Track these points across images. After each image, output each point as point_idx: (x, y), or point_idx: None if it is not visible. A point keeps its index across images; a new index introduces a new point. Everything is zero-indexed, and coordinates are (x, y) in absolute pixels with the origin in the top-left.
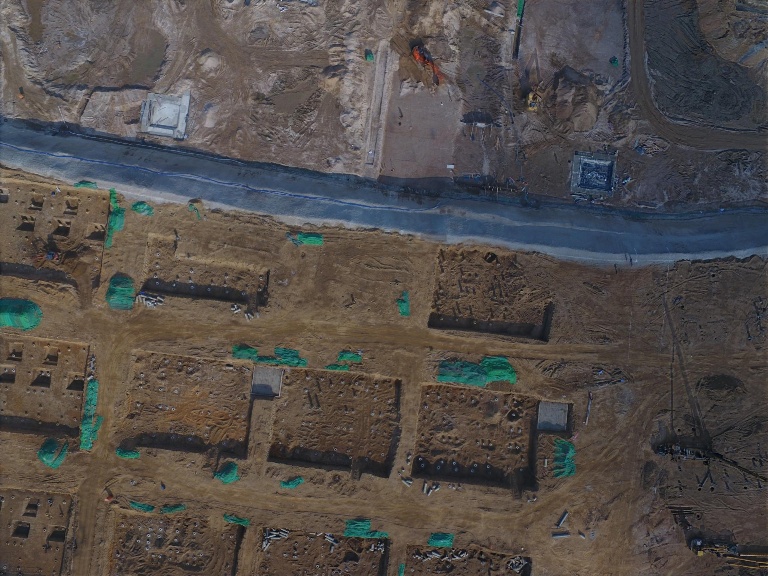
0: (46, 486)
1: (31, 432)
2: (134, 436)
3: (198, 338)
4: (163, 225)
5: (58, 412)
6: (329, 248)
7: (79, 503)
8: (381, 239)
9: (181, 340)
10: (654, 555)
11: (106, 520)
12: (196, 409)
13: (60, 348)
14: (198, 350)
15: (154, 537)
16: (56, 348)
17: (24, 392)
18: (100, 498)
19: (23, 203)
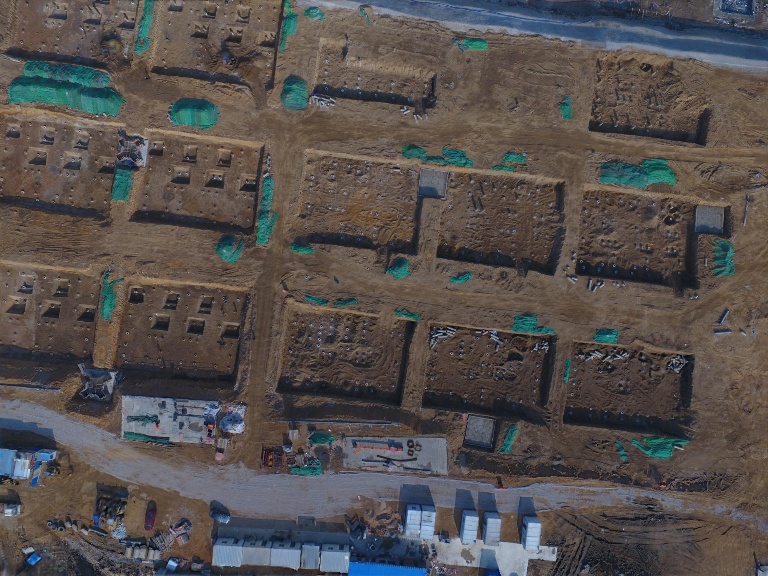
0: (224, 280)
1: (208, 229)
2: (306, 235)
3: (369, 139)
4: (334, 30)
5: (231, 212)
6: (493, 53)
7: (256, 296)
8: (543, 45)
9: (352, 140)
10: None
11: (282, 313)
12: (365, 210)
13: (233, 151)
14: (369, 150)
15: (325, 334)
16: (228, 152)
17: (199, 193)
18: (276, 292)
19: (197, 11)
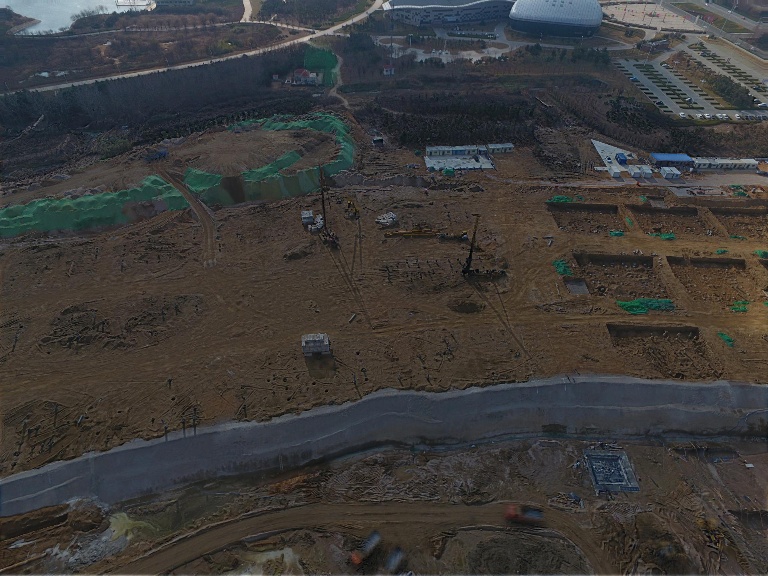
0: None
1: None
2: None
3: None
4: None
5: None
6: None
7: None
8: None
9: None
10: (488, 232)
11: None
12: None
13: None
14: None
15: None
16: None
17: None
18: None
19: None
